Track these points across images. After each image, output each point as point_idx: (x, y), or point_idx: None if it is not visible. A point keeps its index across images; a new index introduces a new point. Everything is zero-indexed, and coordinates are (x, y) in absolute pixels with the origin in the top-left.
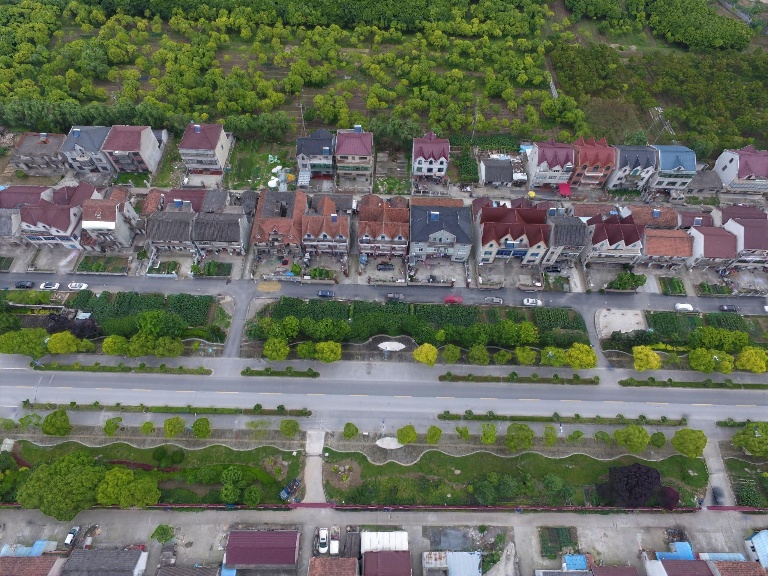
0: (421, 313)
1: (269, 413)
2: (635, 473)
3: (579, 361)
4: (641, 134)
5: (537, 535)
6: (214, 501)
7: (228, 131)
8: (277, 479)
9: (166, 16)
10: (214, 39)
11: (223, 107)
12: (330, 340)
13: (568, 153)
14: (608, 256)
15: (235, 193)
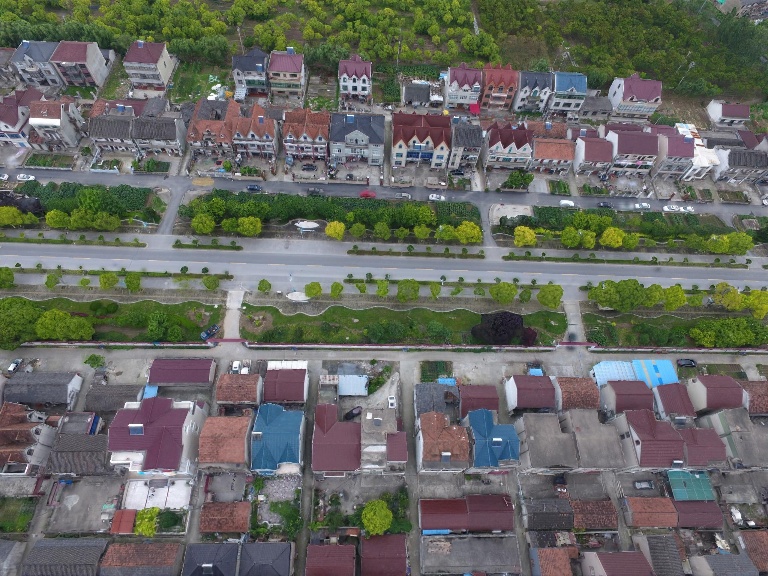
0: None
1: (195, 276)
2: (501, 316)
3: (464, 234)
4: (543, 62)
5: (419, 367)
6: (143, 341)
7: None
8: (199, 325)
9: None
10: None
11: (168, 32)
12: None
13: (476, 75)
14: (505, 161)
15: (176, 104)
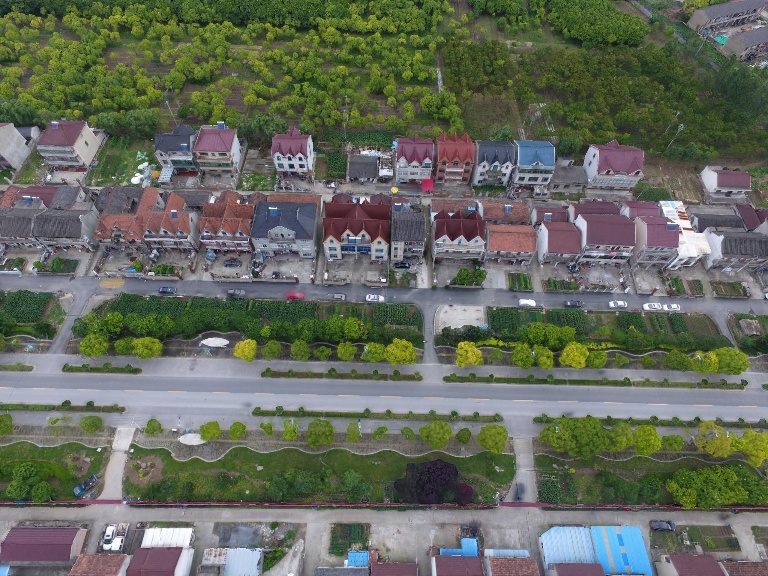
0: (258, 309)
1: (81, 409)
2: (429, 469)
3: (394, 357)
4: (506, 129)
5: (329, 532)
6: (8, 498)
7: (103, 128)
8: (76, 475)
9: (61, 14)
10: (103, 36)
11: (98, 104)
12: (153, 336)
13: (427, 149)
14: (456, 252)
15: (94, 190)
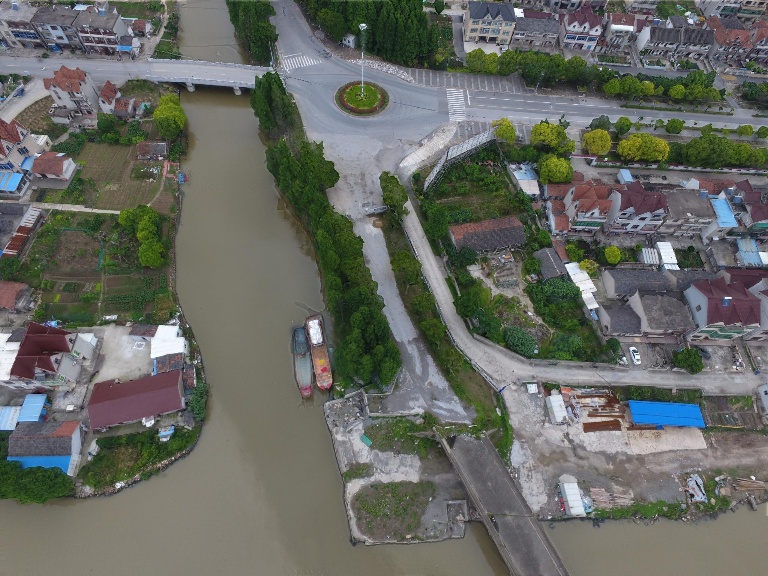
0: None
1: None
2: None
3: None
4: None
5: None
6: None
7: None
8: None
9: None
10: None
11: None
12: None
13: None
14: None
15: None
